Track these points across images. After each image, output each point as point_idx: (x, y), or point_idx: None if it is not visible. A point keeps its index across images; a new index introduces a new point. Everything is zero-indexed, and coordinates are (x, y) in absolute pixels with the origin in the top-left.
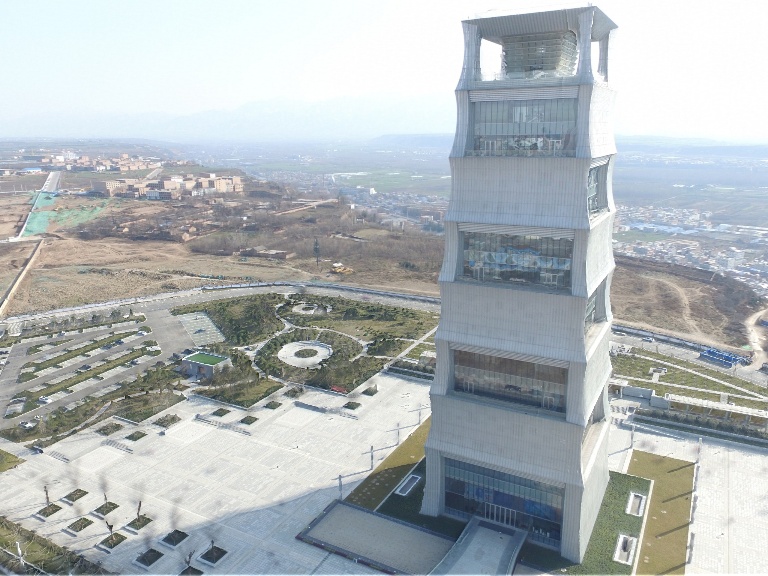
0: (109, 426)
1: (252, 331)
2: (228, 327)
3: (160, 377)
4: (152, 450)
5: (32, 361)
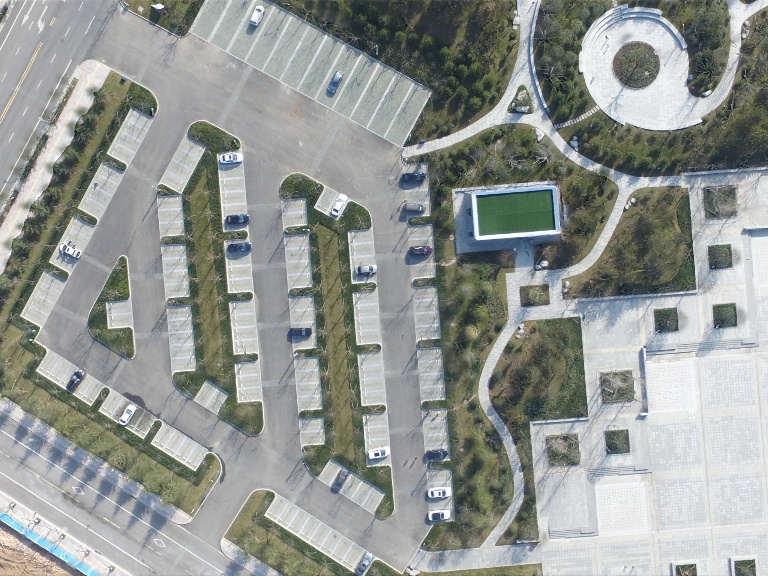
0: (560, 450)
1: (454, 33)
2: (386, 42)
3: (481, 297)
4: (668, 452)
5: (171, 371)
